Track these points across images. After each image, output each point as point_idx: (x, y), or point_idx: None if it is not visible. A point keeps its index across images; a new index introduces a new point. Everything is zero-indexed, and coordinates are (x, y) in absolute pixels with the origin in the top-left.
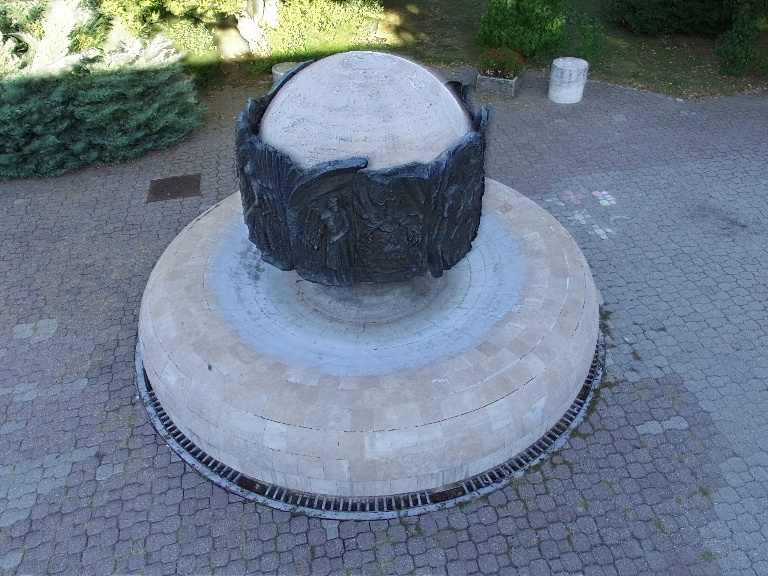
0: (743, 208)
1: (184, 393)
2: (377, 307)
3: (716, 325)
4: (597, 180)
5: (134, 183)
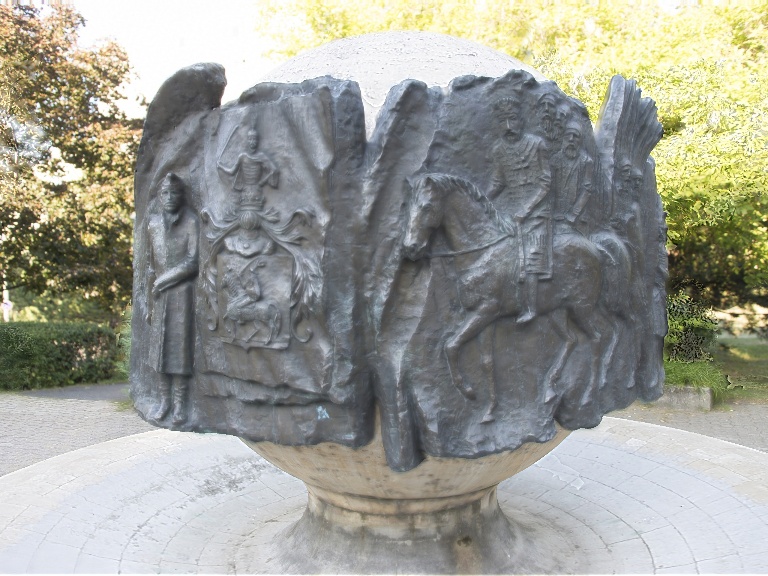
0: None
1: None
2: None
3: None
4: None
5: None
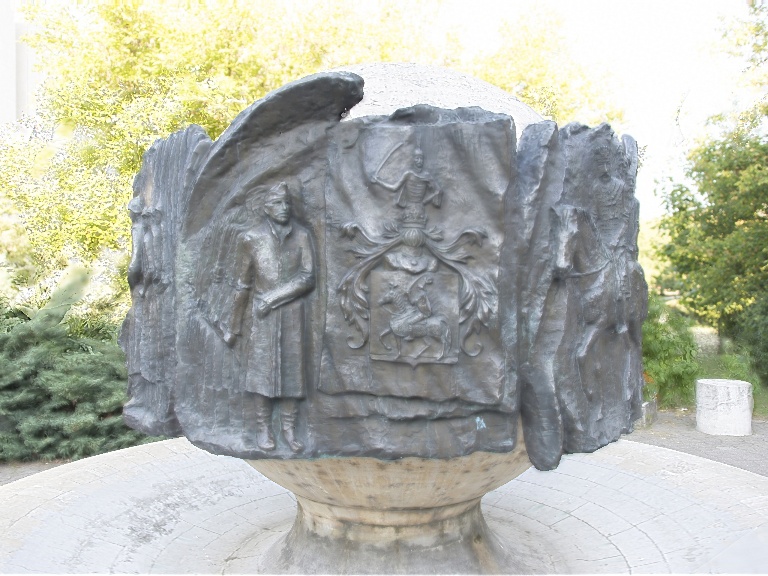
0: None
1: None
2: None
3: None
4: None
5: None
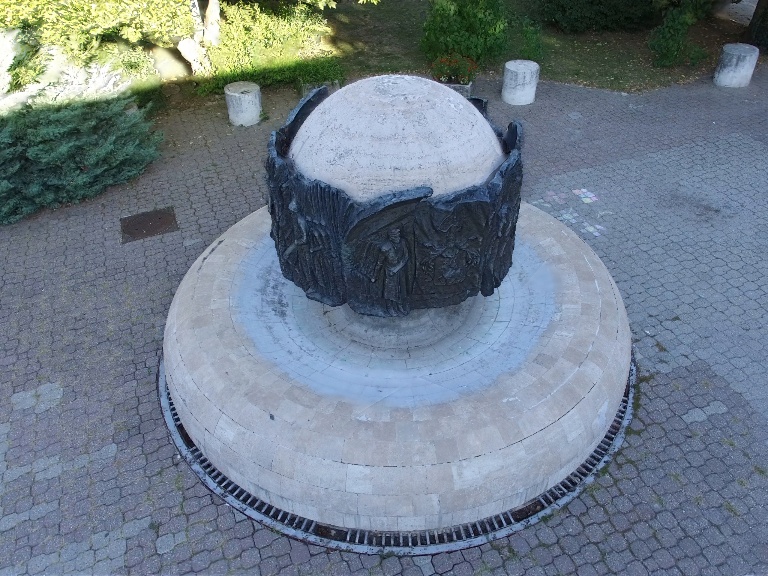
0: (711, 194)
1: (247, 448)
2: (416, 330)
3: (722, 308)
4: (573, 178)
5: (102, 223)
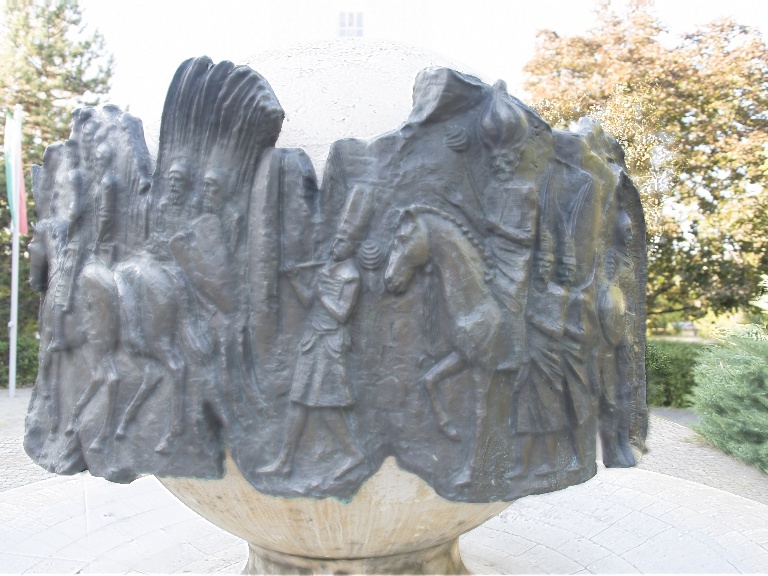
0: None
1: None
2: None
3: None
4: None
5: None
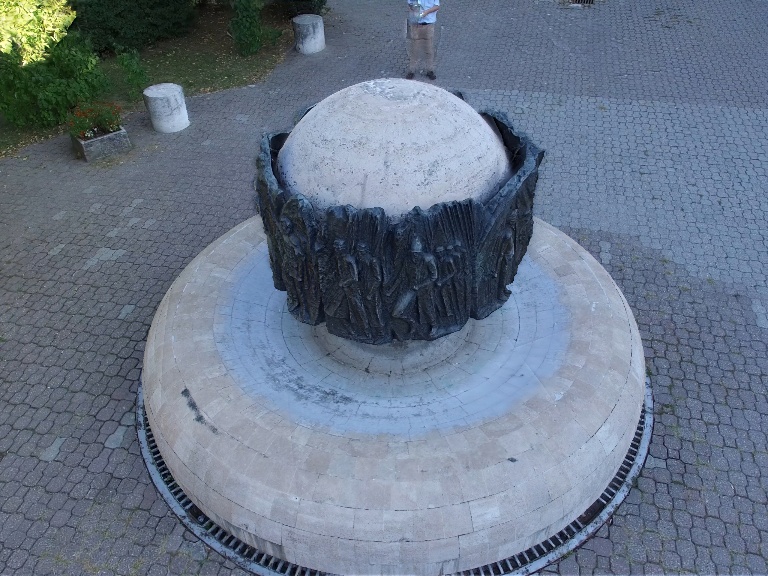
0: None
1: (520, 505)
2: None
3: None
4: None
5: None
